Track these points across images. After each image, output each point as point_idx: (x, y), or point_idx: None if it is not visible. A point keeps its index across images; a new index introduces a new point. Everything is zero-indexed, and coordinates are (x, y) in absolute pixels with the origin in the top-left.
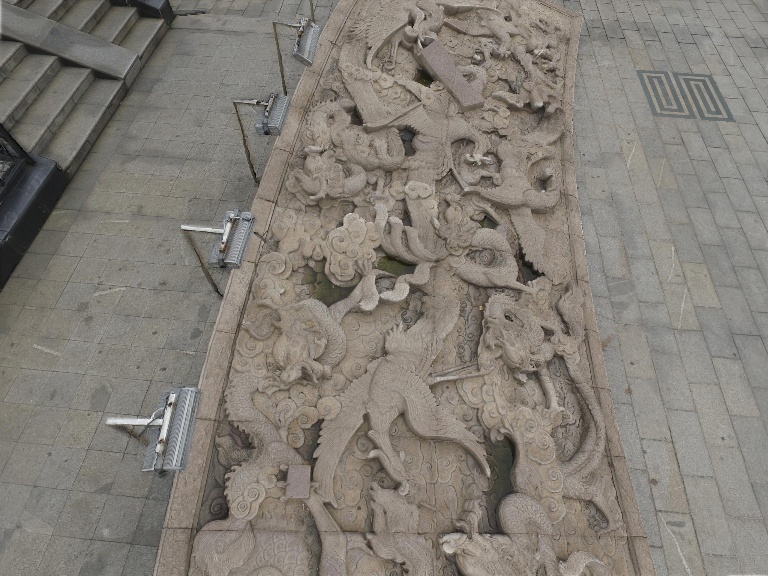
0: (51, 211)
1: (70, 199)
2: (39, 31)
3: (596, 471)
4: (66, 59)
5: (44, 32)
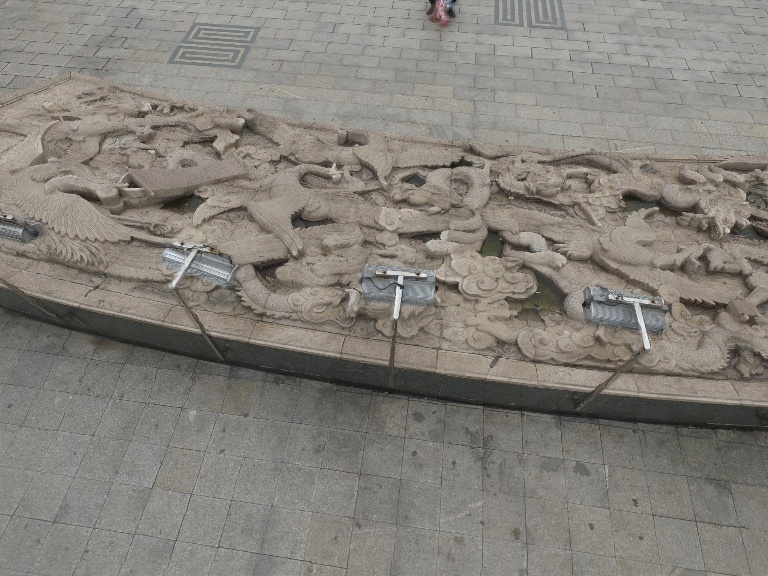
0: None
1: None
2: None
3: (624, 159)
4: None
5: None
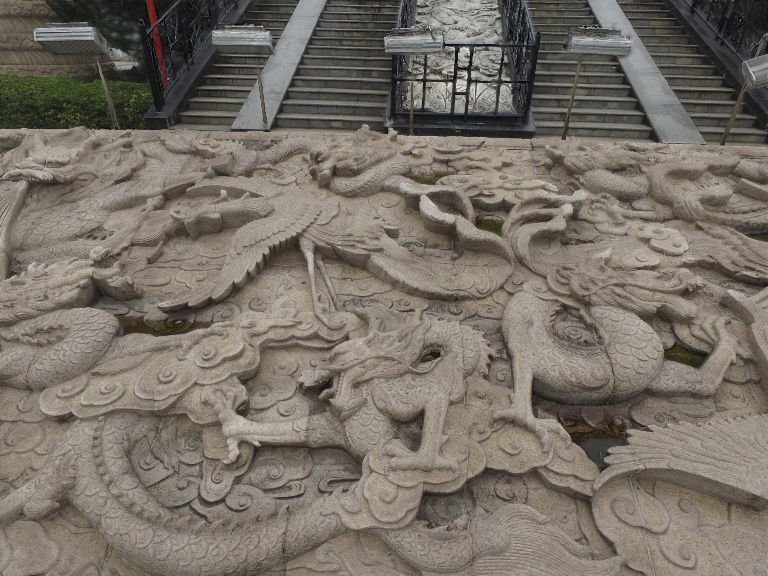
0: None
1: None
2: (660, 101)
3: (71, 478)
4: (647, 117)
5: (662, 103)
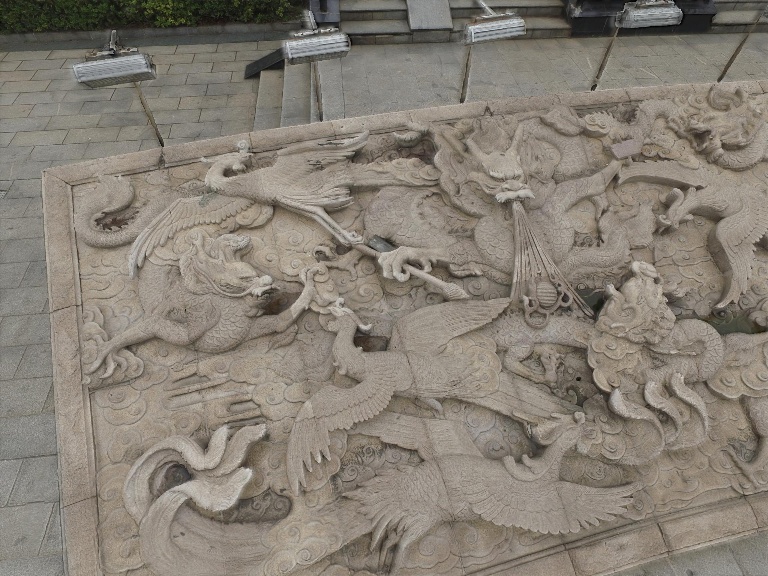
0: (675, 35)
1: (692, 38)
2: None
3: None
4: None
5: None
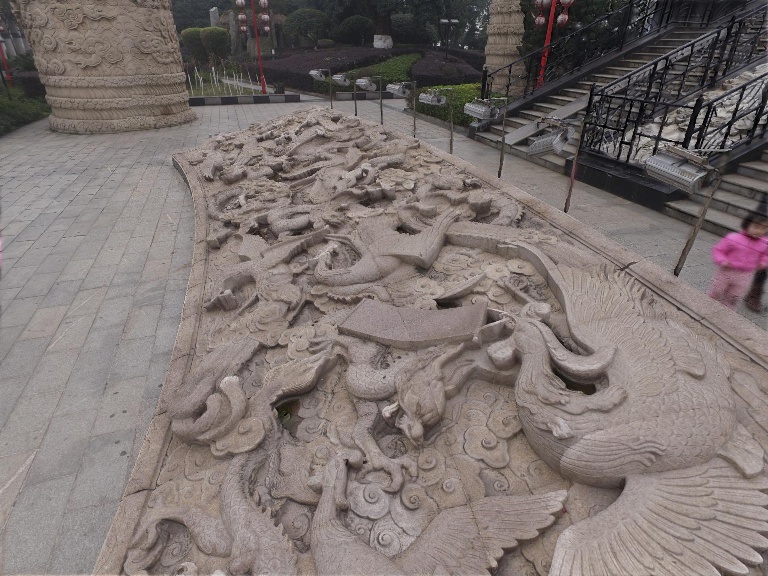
0: None
1: (637, 207)
2: None
3: None
4: None
5: None
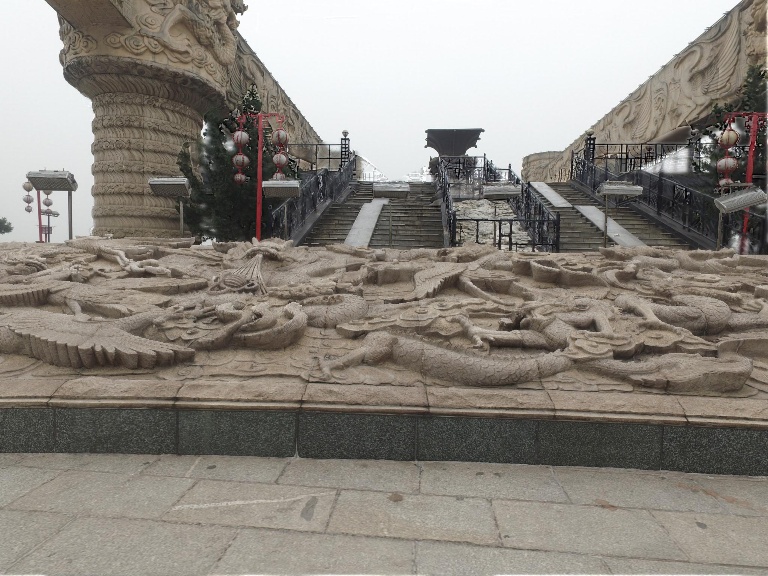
0: None
1: None
2: None
3: None
4: None
5: None
